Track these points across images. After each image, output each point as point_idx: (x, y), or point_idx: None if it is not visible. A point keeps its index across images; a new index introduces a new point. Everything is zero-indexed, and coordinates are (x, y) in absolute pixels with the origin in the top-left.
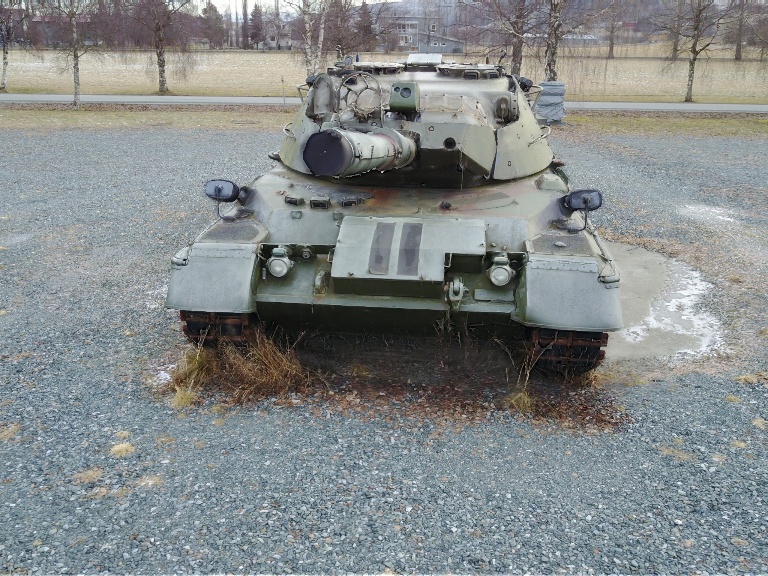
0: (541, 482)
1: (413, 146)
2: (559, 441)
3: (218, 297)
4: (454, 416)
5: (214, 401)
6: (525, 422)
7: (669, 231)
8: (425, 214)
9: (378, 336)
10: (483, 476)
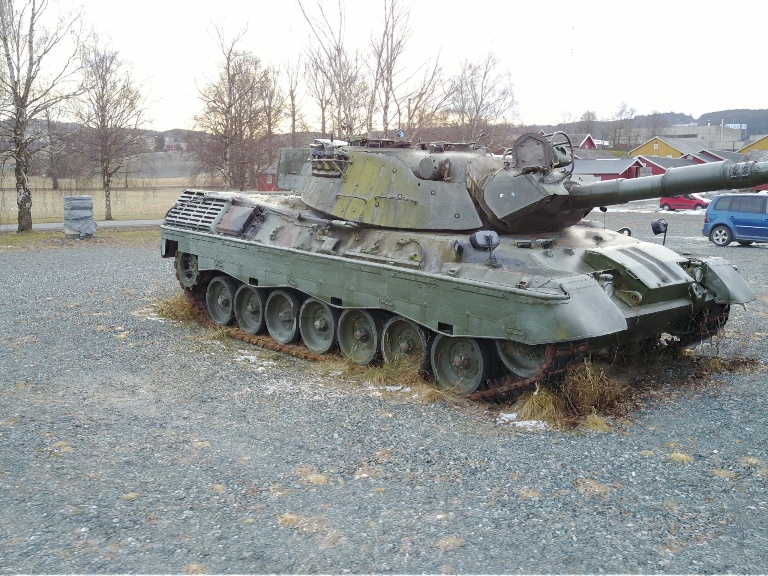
0: None
1: None
2: None
3: (607, 320)
4: (710, 383)
5: (610, 420)
6: (735, 375)
7: None
8: (603, 245)
9: (606, 348)
10: None
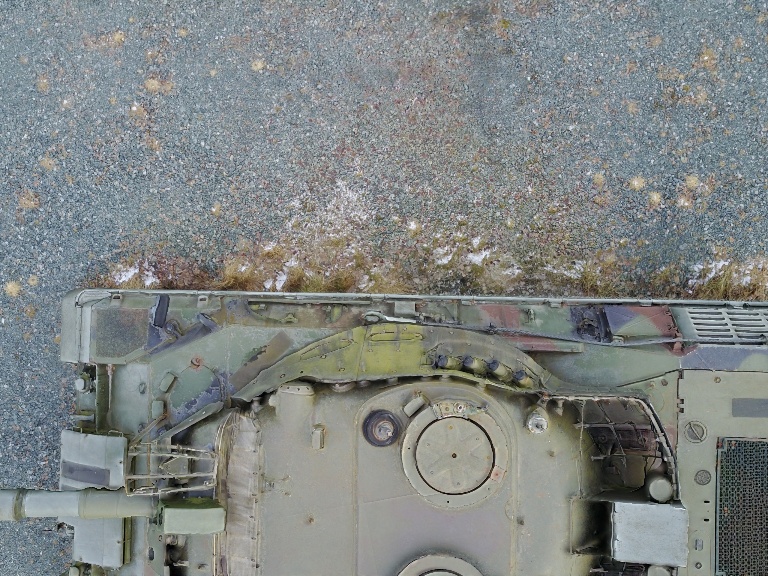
0: (1, 557)
1: None
2: (57, 575)
3: None
4: None
5: None
6: None
7: None
8: None
9: None
10: (5, 521)
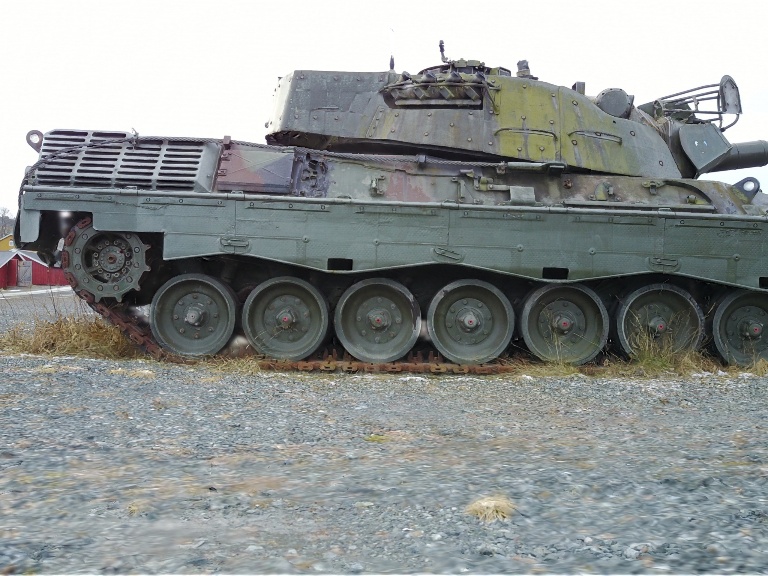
0: None
1: None
2: None
3: None
4: None
5: None
6: None
7: None
8: None
9: None
10: None
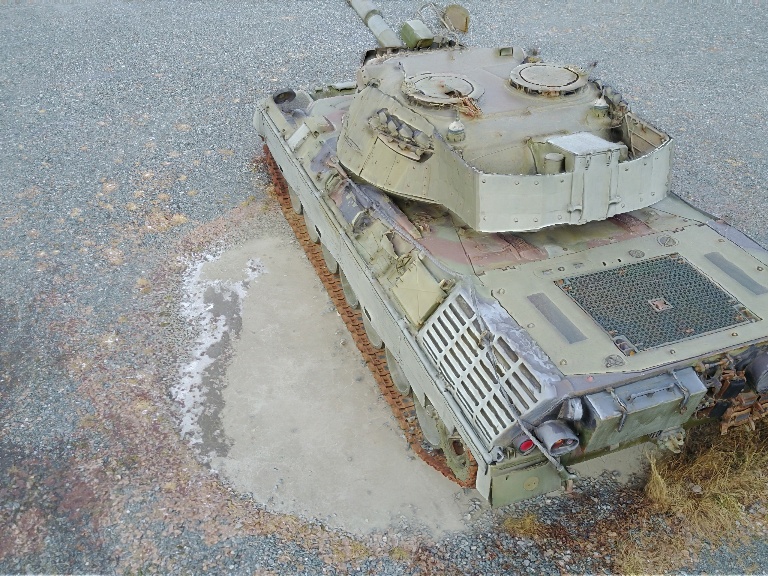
0: None
1: (387, 45)
2: None
3: None
4: None
5: None
6: None
7: (218, 571)
8: None
9: None
10: None
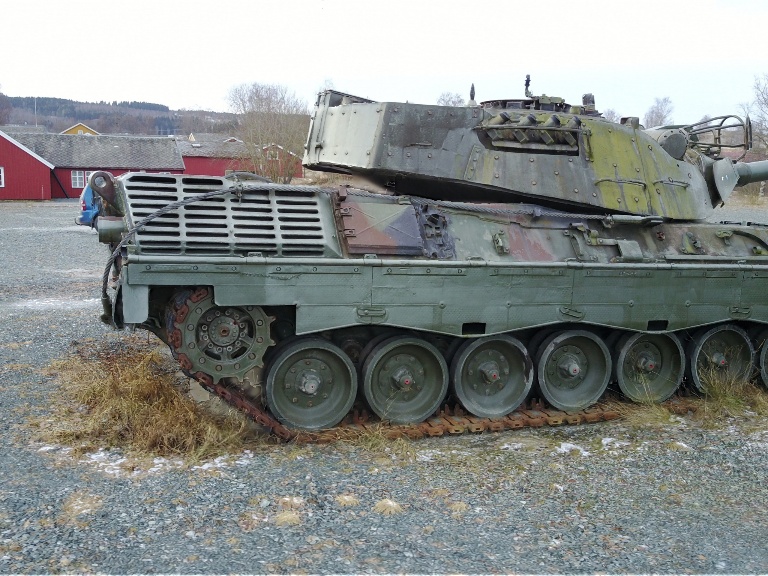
0: None
1: None
2: None
3: None
4: None
5: None
6: None
7: None
8: None
9: None
10: None
